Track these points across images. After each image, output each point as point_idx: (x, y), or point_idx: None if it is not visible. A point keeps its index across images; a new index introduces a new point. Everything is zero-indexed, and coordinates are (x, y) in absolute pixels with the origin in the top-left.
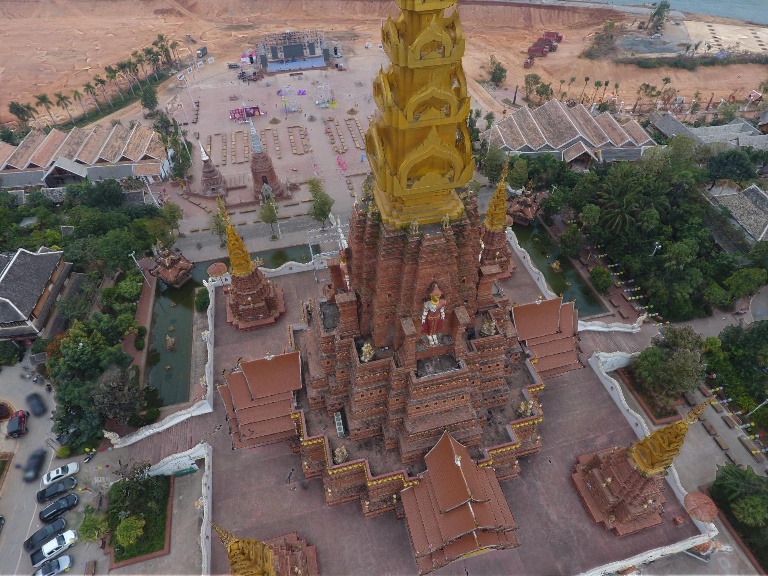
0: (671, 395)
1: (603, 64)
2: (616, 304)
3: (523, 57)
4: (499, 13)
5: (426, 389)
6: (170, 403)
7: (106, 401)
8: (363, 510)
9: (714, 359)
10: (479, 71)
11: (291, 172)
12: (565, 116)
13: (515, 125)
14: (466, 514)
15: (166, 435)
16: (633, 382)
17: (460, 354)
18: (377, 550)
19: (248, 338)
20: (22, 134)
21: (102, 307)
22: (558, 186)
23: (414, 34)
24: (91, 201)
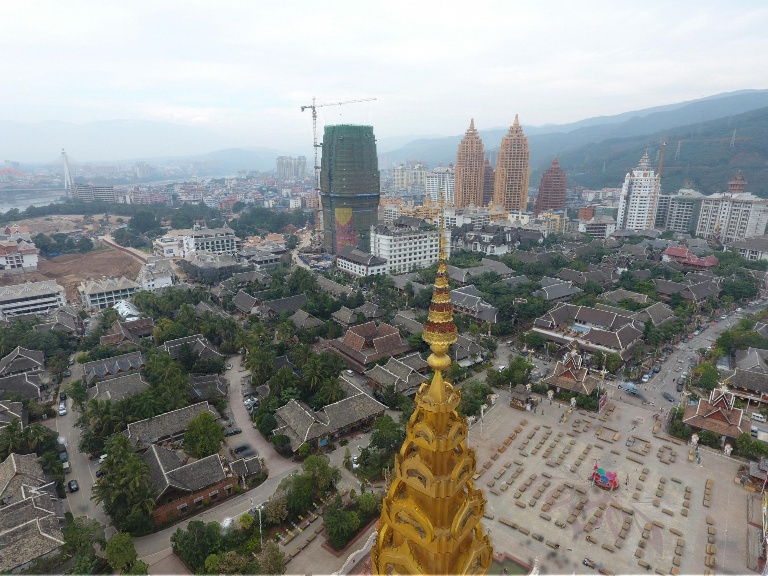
0: None
1: None
2: None
3: None
4: None
5: None
6: None
7: None
8: None
9: None
10: None
11: None
12: None
13: None
14: None
15: None
16: None
17: None
18: None
19: None
20: None
21: None
22: None
23: None
24: None
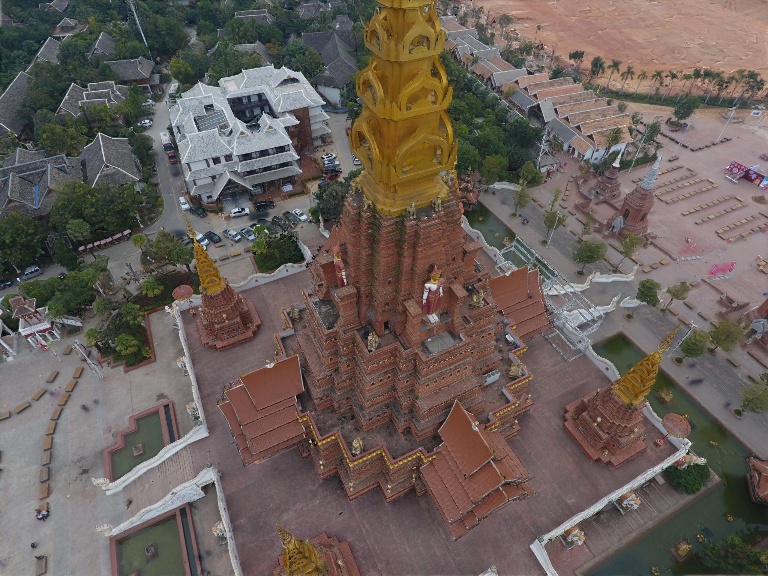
0: None
1: None
2: None
3: None
4: None
5: None
6: None
7: (325, 197)
8: None
9: None
10: None
11: (682, 239)
12: None
13: None
14: None
15: None
16: None
17: (339, 324)
18: None
19: None
20: None
21: None
22: None
23: None
24: (512, 132)
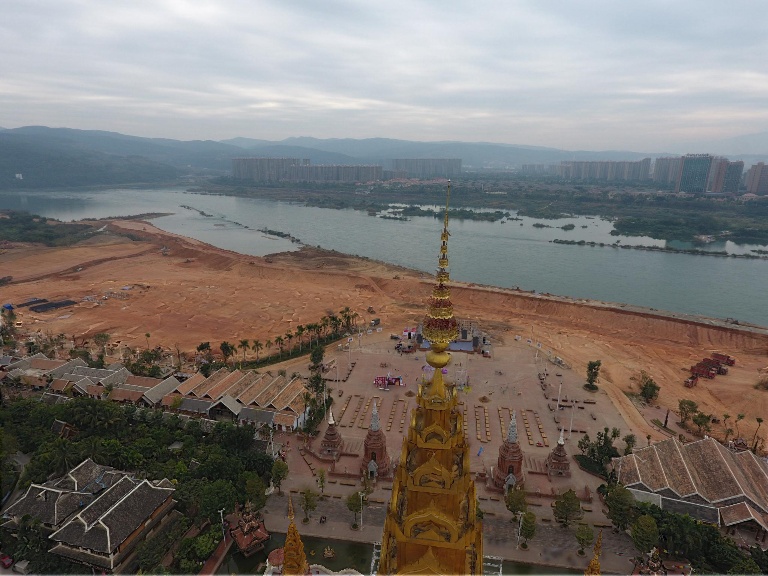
0: None
1: None
2: None
3: (684, 375)
4: (660, 326)
5: None
6: None
7: None
8: None
9: None
10: (629, 382)
11: None
12: (724, 463)
13: (657, 459)
14: None
15: None
16: None
17: None
18: None
19: None
20: (217, 368)
21: None
22: (706, 561)
23: (423, 457)
24: (226, 441)
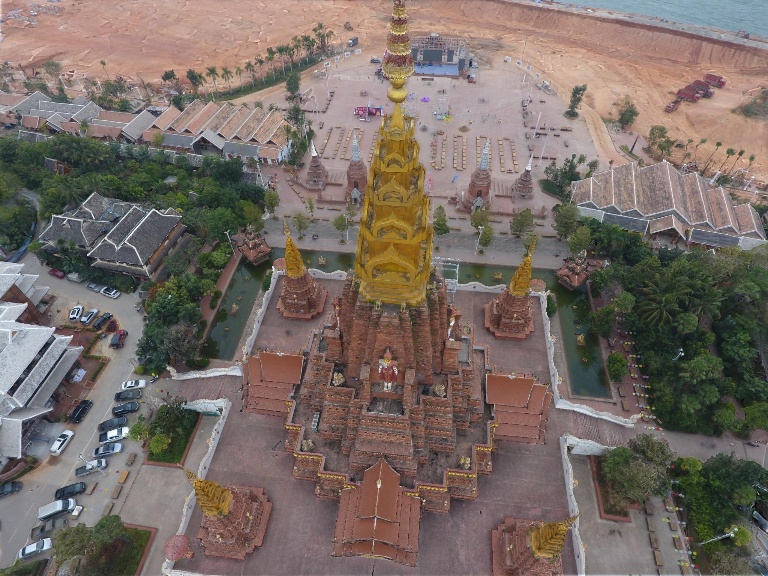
0: (628, 497)
1: (758, 125)
2: (622, 394)
3: (669, 99)
4: (664, 42)
5: (372, 422)
6: (219, 357)
7: (171, 346)
8: (315, 491)
9: (687, 480)
10: (610, 108)
11: None
12: (668, 184)
13: (611, 181)
14: (371, 526)
15: (206, 382)
16: (599, 472)
17: (407, 404)
18: (315, 525)
19: (287, 325)
20: (189, 100)
21: (197, 267)
22: (623, 258)
23: (387, 179)
24: (217, 174)
